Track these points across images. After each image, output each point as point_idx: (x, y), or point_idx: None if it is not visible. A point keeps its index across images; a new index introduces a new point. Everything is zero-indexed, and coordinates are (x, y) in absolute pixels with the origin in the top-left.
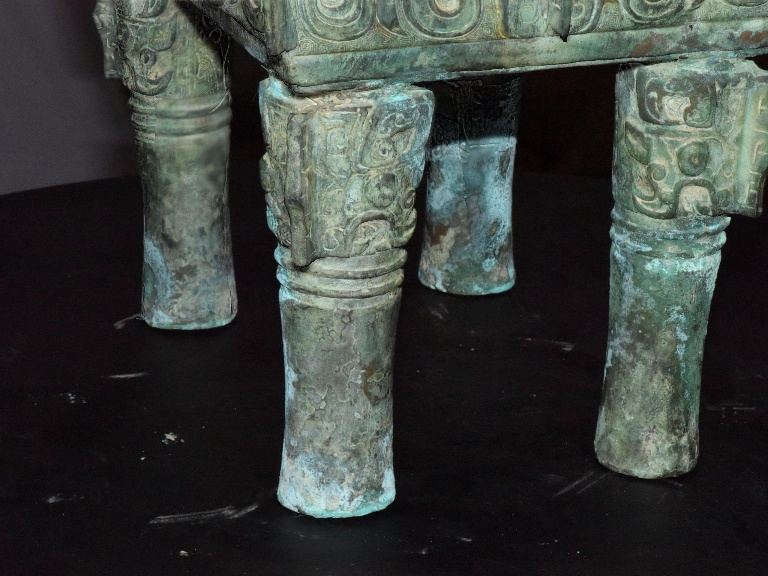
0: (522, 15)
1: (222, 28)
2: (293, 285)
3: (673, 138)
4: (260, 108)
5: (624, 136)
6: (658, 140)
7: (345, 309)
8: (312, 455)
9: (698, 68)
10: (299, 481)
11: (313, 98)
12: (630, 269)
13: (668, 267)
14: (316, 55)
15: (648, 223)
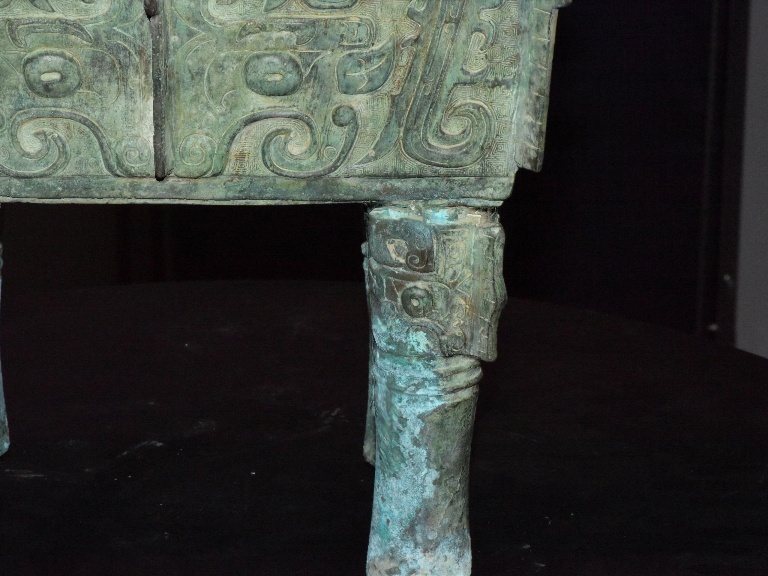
0: None
1: (303, 199)
2: (449, 390)
3: None
4: (429, 241)
5: None
6: None
7: (476, 392)
8: (452, 537)
9: None
10: (443, 567)
11: None
12: None
13: None
14: None
15: None
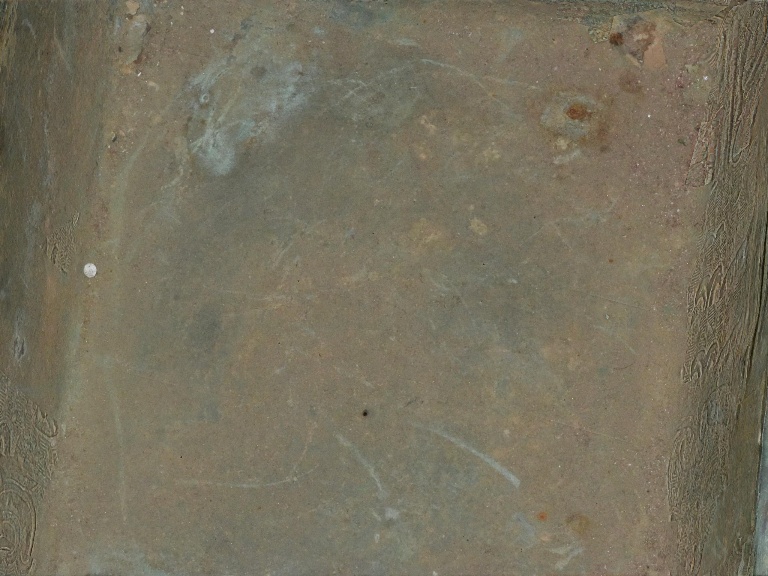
0: None
1: None
2: None
3: None
4: None
5: None
6: None
7: None
8: None
9: None
10: None
11: None
12: None
13: None
14: (706, 7)
15: None
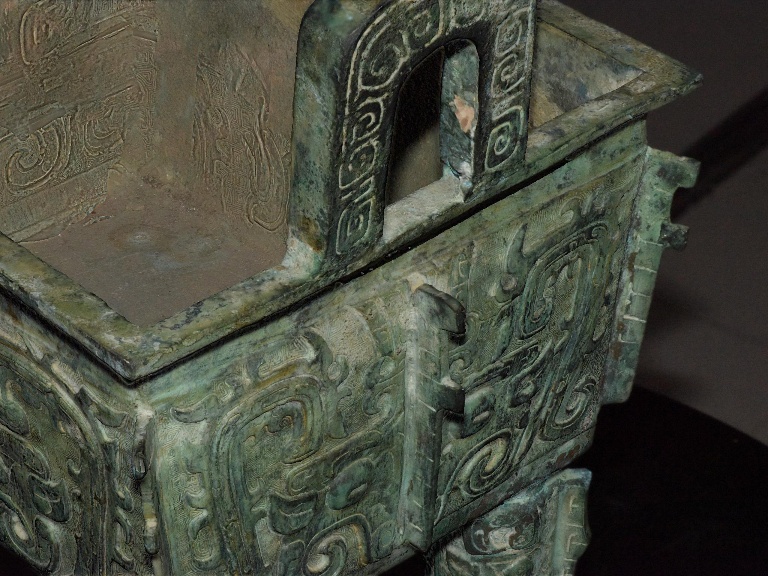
0: (382, 542)
1: None
2: None
3: (500, 562)
4: None
5: (444, 561)
6: (485, 566)
7: None
8: None
9: (519, 499)
10: None
11: None
12: None
13: None
14: None
15: None
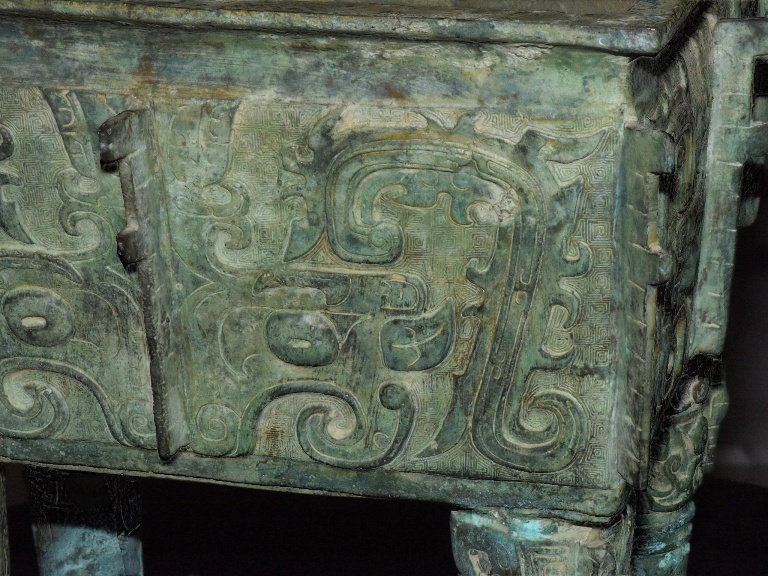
0: None
1: (354, 492)
2: None
3: (687, 422)
4: (513, 561)
5: None
6: (675, 430)
7: None
8: None
9: None
10: None
11: (583, 523)
12: (641, 575)
13: (677, 556)
14: None
15: (660, 520)
